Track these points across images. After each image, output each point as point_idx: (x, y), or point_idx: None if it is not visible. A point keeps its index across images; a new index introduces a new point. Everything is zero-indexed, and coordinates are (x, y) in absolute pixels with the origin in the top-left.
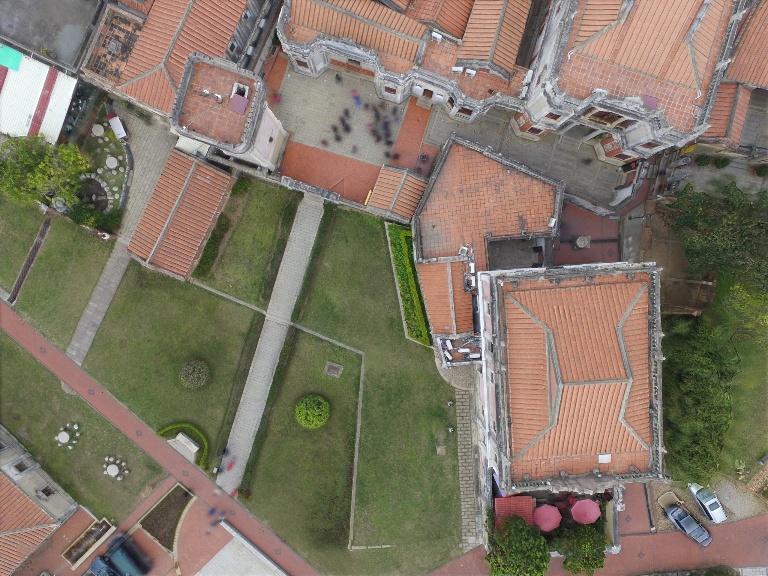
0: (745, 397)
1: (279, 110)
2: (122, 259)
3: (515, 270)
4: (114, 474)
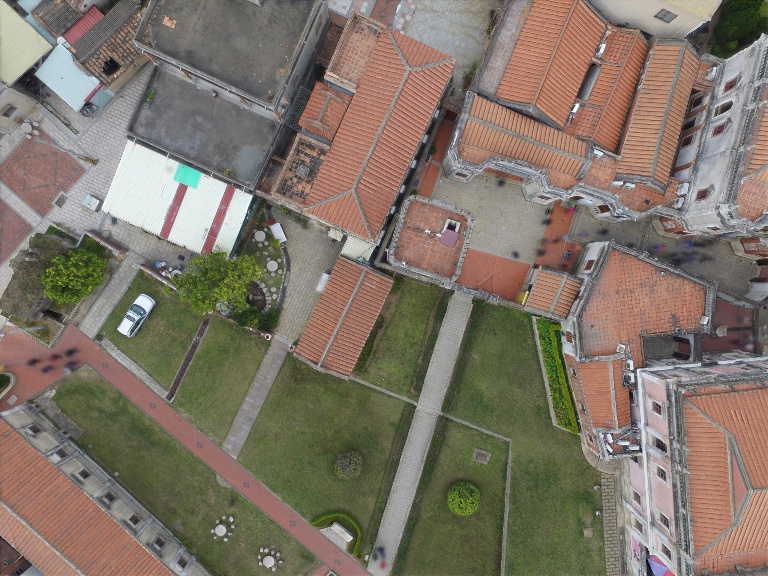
0: None
1: None
2: (278, 356)
3: (672, 366)
4: (270, 565)
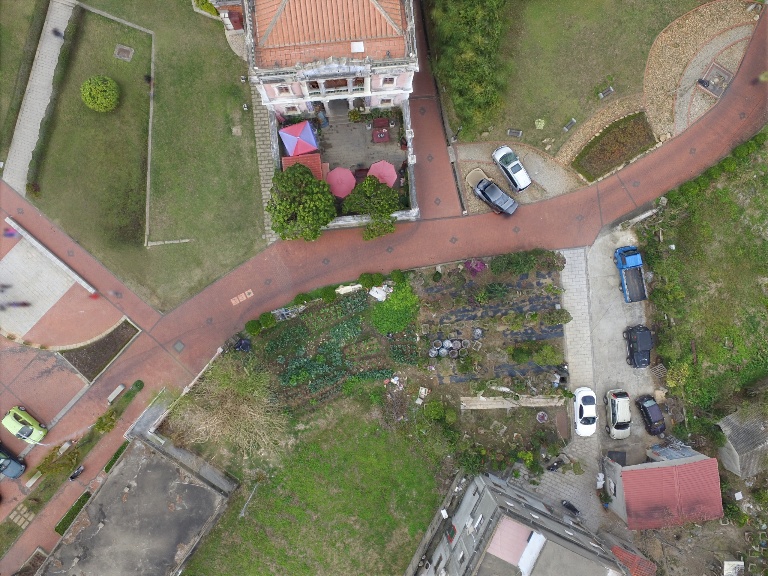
0: (543, 60)
1: None
2: None
3: None
4: None
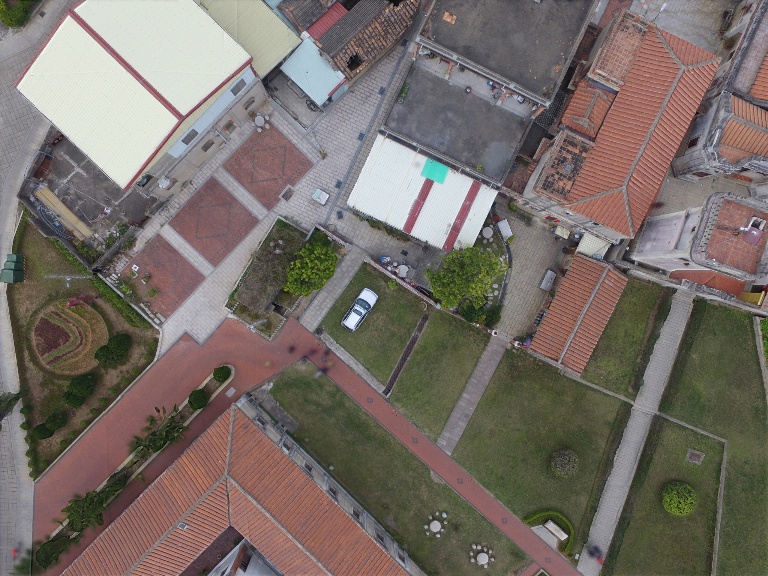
0: None
1: (658, 212)
2: (496, 352)
3: None
4: (484, 562)
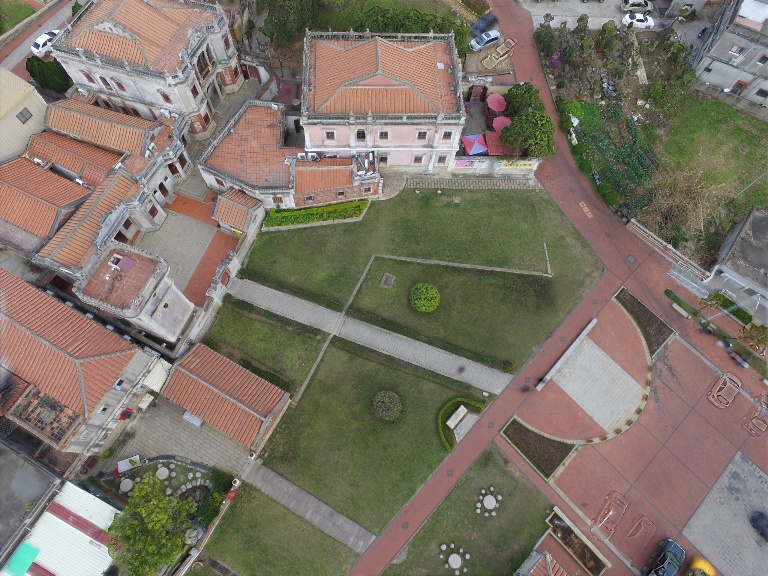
0: None
1: None
2: (264, 476)
3: None
4: (494, 501)
